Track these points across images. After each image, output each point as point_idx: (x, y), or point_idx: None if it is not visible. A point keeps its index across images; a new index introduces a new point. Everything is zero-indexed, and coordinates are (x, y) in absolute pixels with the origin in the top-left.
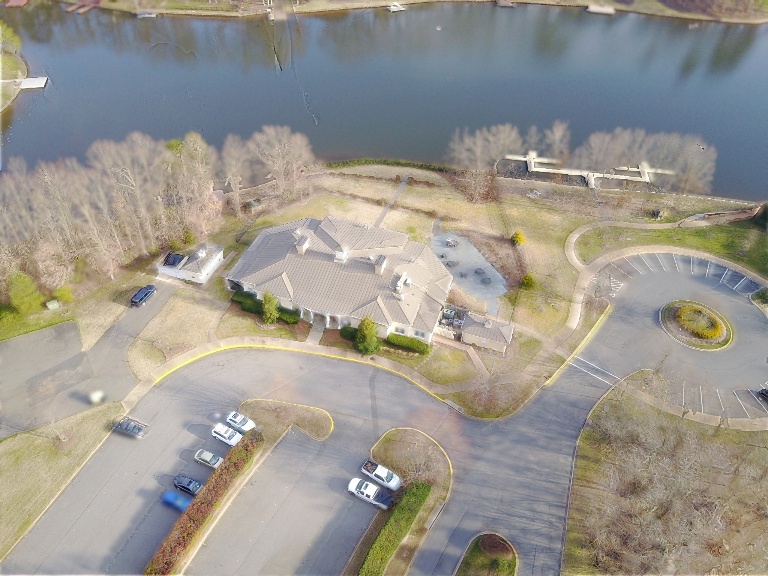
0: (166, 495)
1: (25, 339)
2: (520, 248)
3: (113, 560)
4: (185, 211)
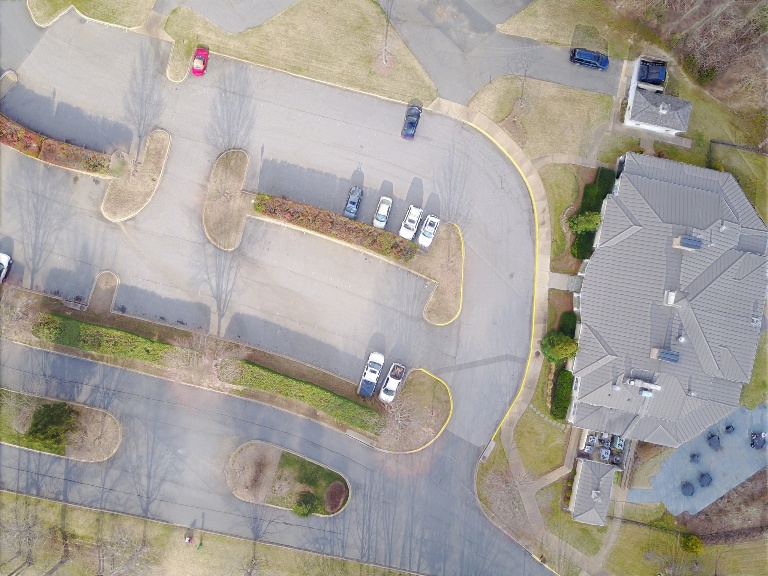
0: (343, 183)
1: None
2: (767, 537)
3: (279, 160)
4: (748, 54)
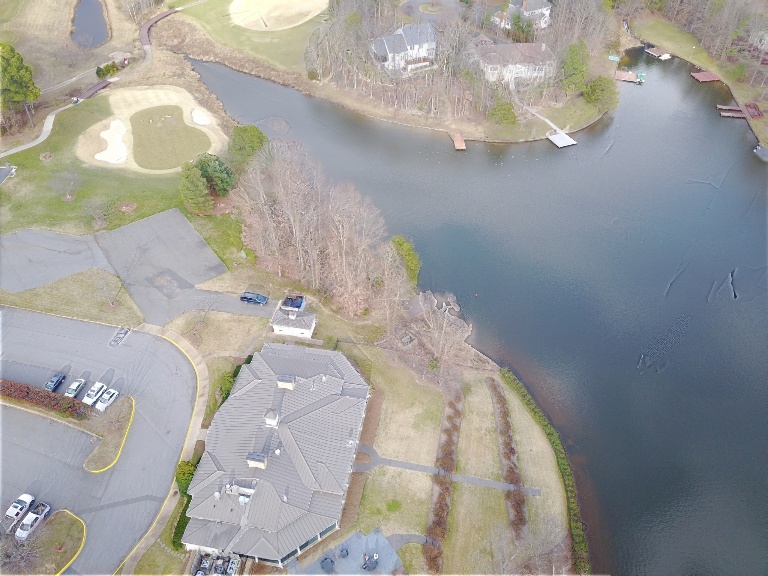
0: (53, 373)
1: (208, 254)
2: None
3: (11, 360)
4: None
